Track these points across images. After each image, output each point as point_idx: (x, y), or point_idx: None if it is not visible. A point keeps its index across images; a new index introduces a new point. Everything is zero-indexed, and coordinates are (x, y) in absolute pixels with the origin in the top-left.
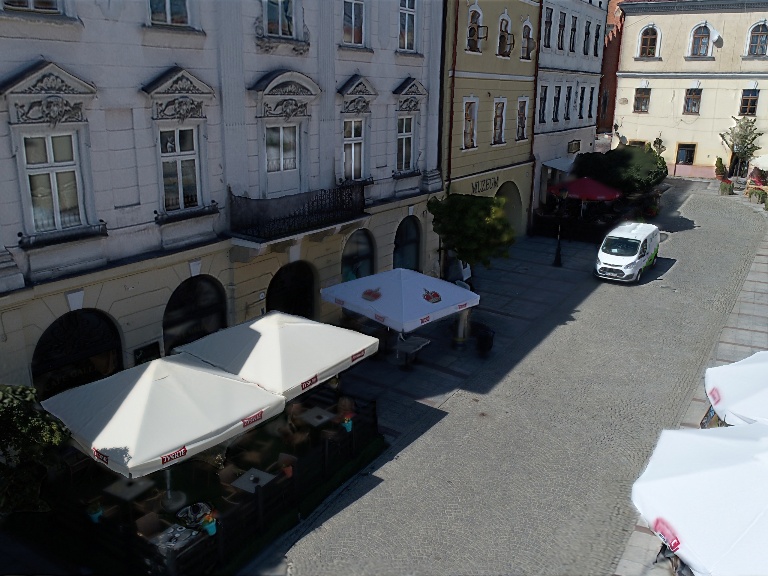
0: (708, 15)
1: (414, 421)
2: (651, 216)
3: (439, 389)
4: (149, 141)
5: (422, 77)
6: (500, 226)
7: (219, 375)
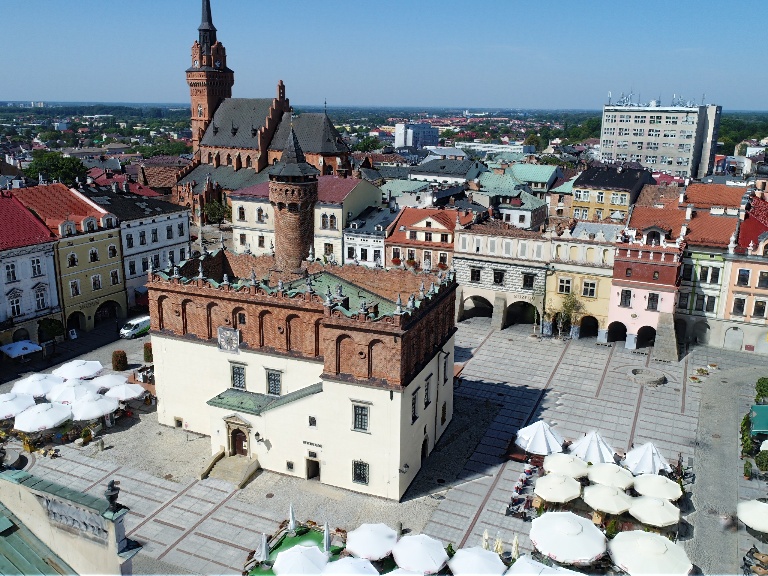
0: (261, 204)
1: (13, 378)
2: None
3: (27, 371)
4: None
5: (47, 280)
6: (55, 328)
7: None
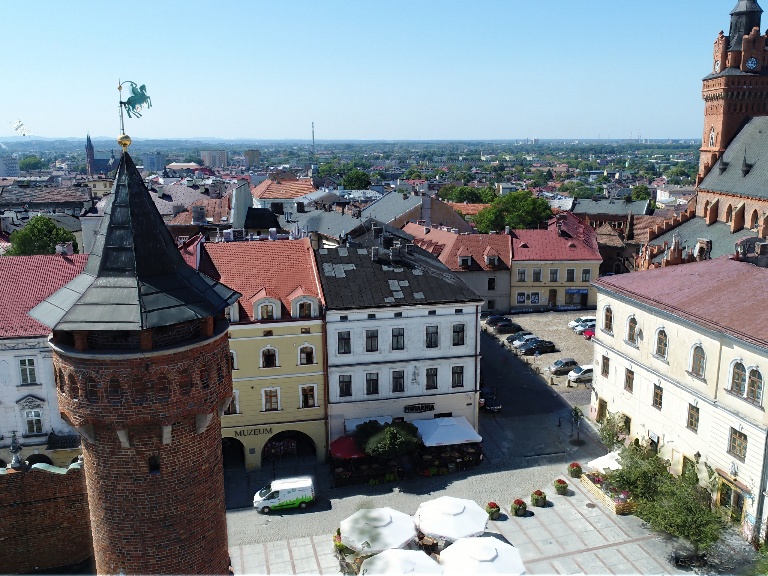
0: (635, 309)
1: None
2: (424, 475)
3: None
4: (20, 415)
5: None
6: None
7: None
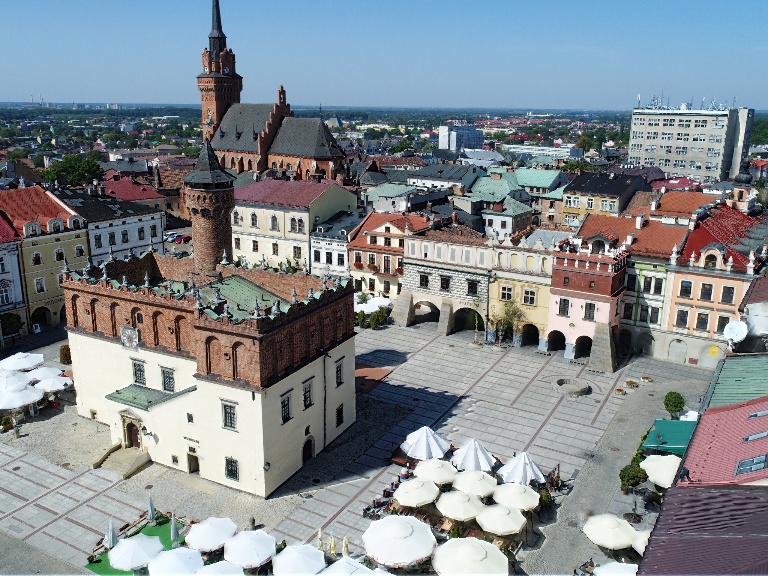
0: (237, 207)
1: None
2: None
3: None
4: None
5: (11, 277)
6: (13, 322)
7: None
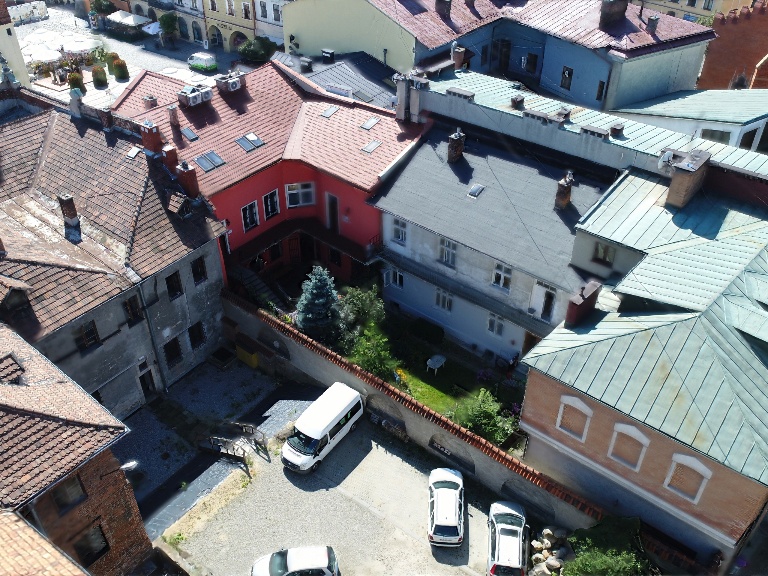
0: None
1: None
2: None
3: None
4: None
5: None
6: None
7: (121, 15)
